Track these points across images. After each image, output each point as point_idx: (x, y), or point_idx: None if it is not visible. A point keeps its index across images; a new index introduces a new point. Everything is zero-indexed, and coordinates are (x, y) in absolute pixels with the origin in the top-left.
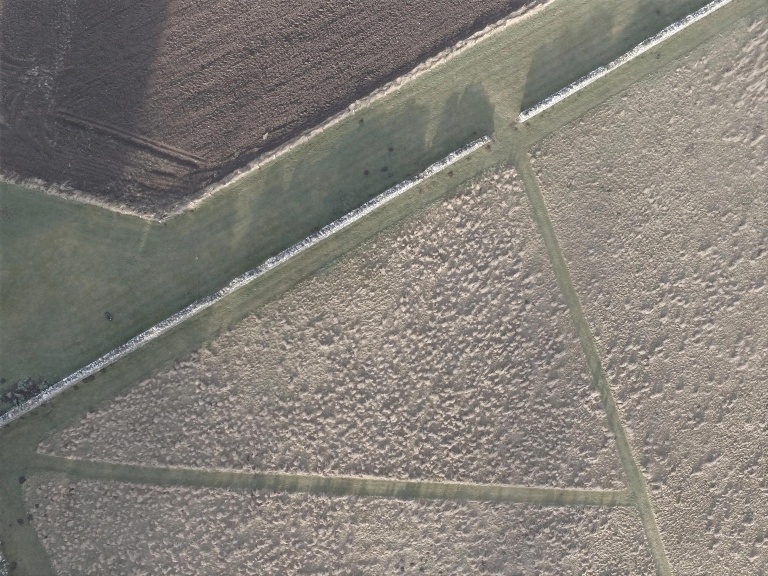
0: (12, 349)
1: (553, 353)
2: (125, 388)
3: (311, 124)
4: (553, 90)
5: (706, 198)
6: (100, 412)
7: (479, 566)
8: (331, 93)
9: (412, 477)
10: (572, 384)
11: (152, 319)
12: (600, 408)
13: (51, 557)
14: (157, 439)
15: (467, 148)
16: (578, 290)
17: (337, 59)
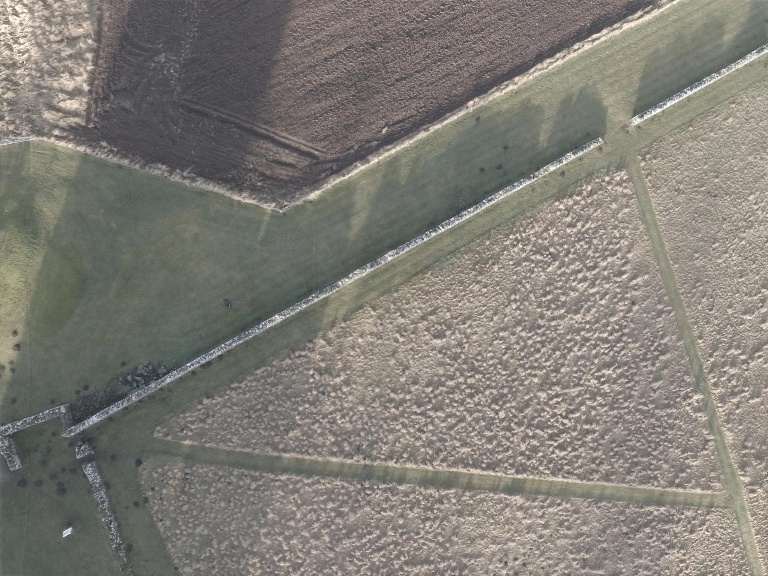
0: (133, 332)
1: (658, 355)
2: (241, 375)
3: (429, 120)
4: (665, 95)
5: None
6: (216, 398)
7: (580, 563)
8: (450, 90)
9: (518, 473)
10: (675, 386)
11: (270, 307)
12: (701, 411)
13: (166, 540)
14: (271, 427)
15: (584, 149)
16: (683, 293)
17: (457, 56)
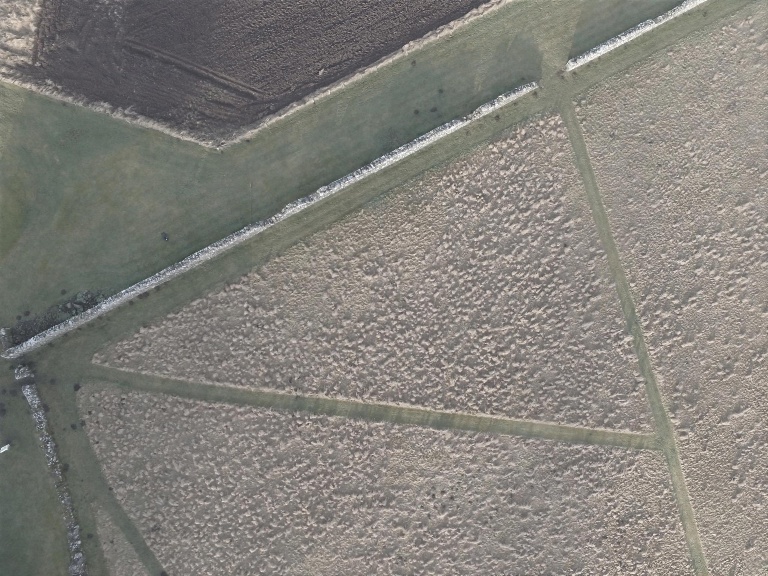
0: (73, 262)
1: (589, 296)
2: (177, 306)
3: (365, 63)
4: (601, 41)
5: (746, 155)
6: (153, 327)
7: (508, 498)
8: (386, 34)
9: (447, 408)
10: (606, 328)
11: (206, 241)
12: (632, 353)
13: (101, 462)
14: (205, 357)
15: (516, 91)
16: (616, 237)
17: (393, 1)
